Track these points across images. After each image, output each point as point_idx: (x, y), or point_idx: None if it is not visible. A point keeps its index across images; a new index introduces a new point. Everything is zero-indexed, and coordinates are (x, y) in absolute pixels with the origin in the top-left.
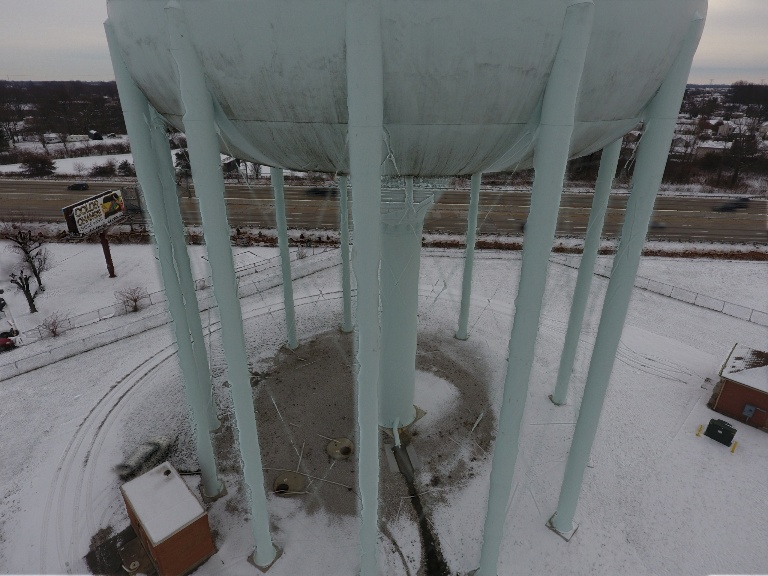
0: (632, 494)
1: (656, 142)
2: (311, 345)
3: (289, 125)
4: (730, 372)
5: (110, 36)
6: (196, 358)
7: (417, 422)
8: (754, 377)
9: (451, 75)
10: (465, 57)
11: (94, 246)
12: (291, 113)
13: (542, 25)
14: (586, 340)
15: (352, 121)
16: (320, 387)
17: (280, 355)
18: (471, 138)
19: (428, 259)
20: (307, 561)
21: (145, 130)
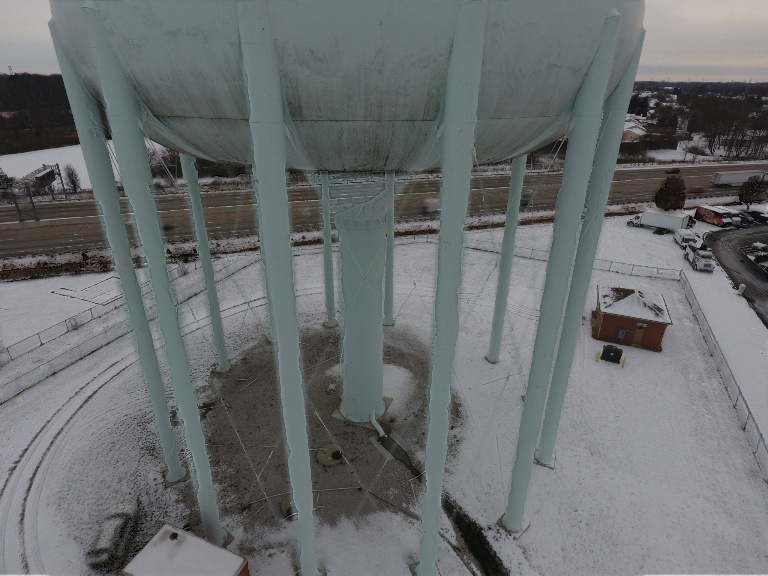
0: (578, 418)
1: (616, 128)
2: (244, 363)
3: (368, 124)
4: (605, 307)
5: (95, 23)
6: (155, 402)
7: (389, 409)
8: (622, 307)
9: (529, 74)
10: (543, 58)
11: None
12: (376, 112)
13: (592, 33)
14: (489, 305)
15: (456, 118)
16: (277, 402)
17: (215, 381)
18: (521, 130)
19: (320, 256)
20: (355, 569)
21: (140, 137)
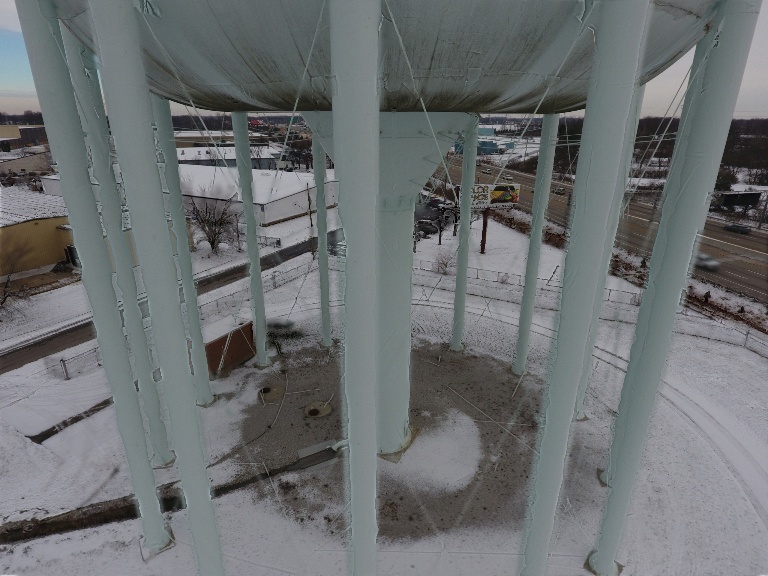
0: None
1: None
2: (468, 357)
3: None
4: None
5: None
6: None
7: None
8: None
9: None
10: None
11: (516, 233)
12: None
13: None
14: None
15: None
16: None
17: (437, 346)
18: None
19: None
20: None
21: None
